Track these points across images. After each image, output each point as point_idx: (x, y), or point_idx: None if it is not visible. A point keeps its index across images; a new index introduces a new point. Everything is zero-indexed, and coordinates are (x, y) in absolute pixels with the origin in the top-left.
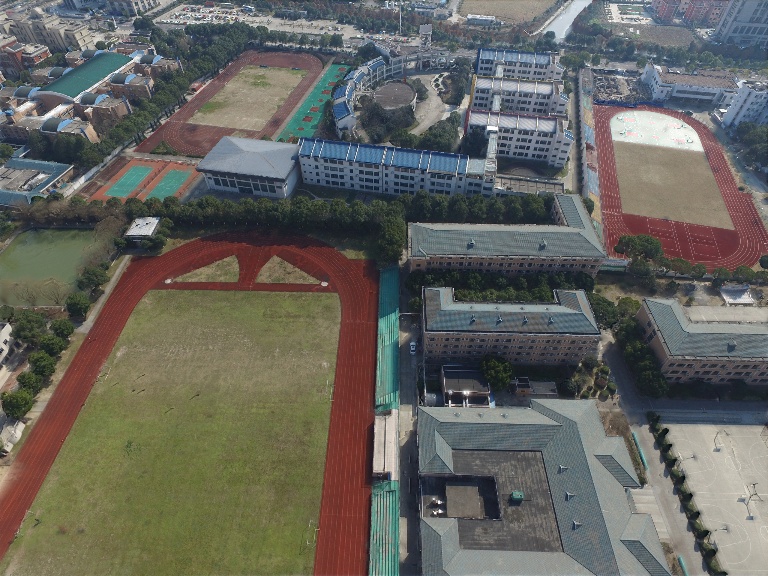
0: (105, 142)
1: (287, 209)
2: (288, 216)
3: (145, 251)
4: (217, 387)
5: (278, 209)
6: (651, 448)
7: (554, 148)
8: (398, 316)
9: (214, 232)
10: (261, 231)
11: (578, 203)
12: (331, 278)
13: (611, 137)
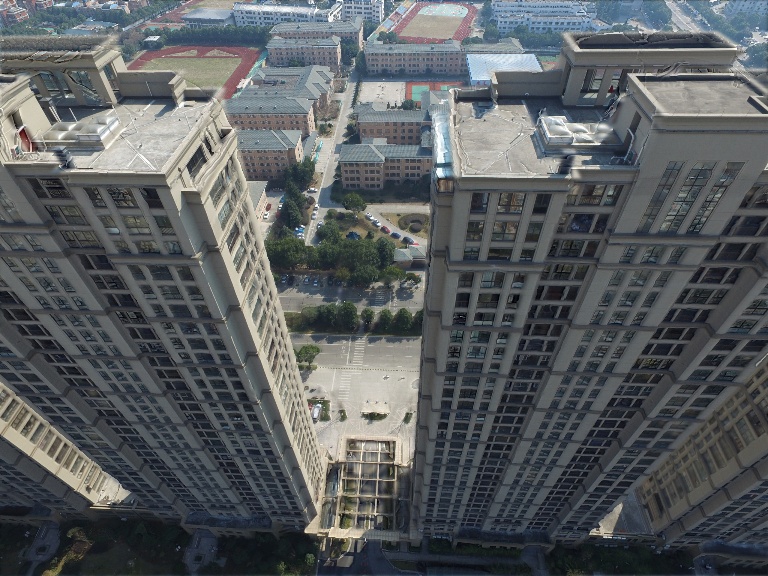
0: (135, 14)
1: (223, 28)
2: (223, 32)
3: (153, 49)
4: None
5: (218, 28)
6: (353, 86)
7: (373, 11)
8: (264, 59)
9: (188, 44)
10: (211, 43)
11: (359, 18)
12: (240, 54)
13: (417, 13)
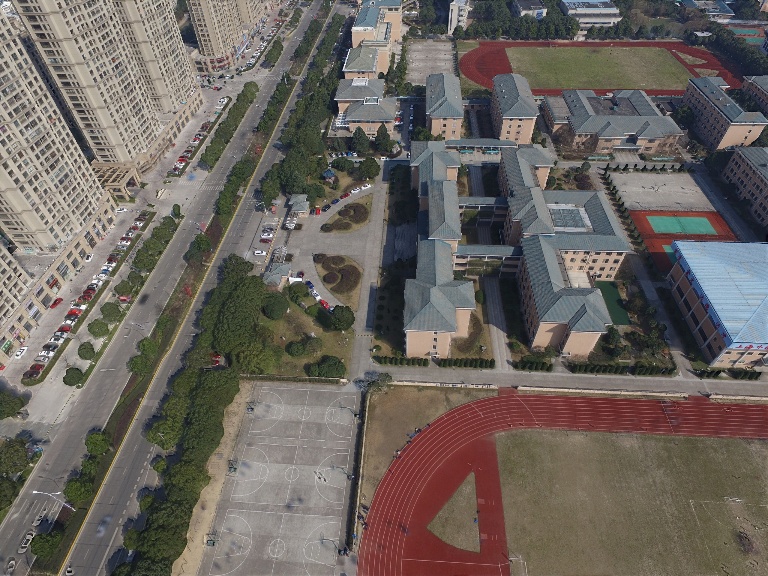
0: (764, 12)
1: (757, 56)
2: (752, 60)
3: None
4: (624, 67)
5: (754, 54)
6: (668, 167)
7: None
8: None
9: (721, 55)
10: (736, 66)
11: None
12: None
13: None
